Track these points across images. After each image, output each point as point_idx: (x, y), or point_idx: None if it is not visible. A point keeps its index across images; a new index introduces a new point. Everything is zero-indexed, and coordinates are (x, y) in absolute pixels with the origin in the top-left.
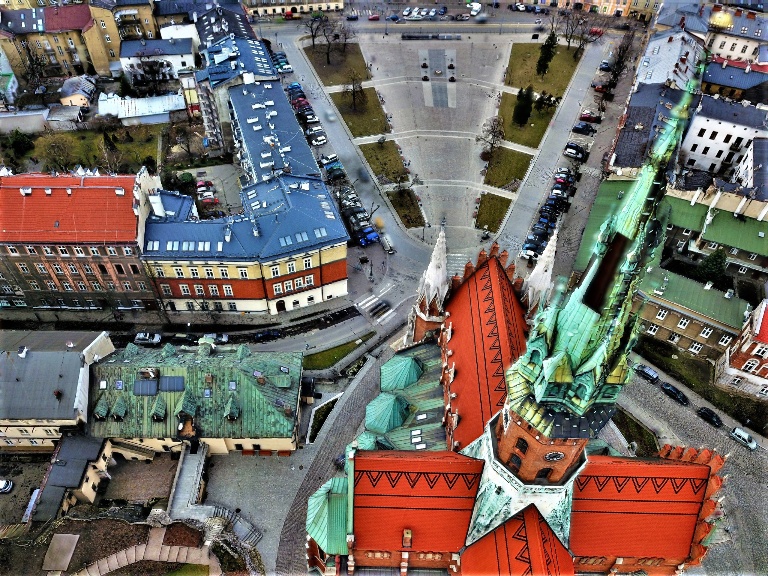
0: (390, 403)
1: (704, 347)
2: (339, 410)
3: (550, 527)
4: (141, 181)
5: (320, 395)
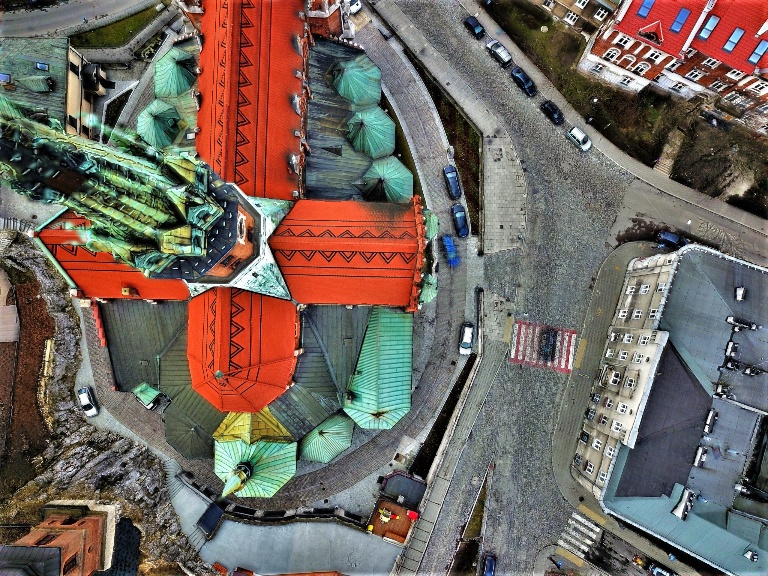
0: (151, 122)
1: (579, 19)
2: (134, 104)
3: (257, 292)
4: None
5: (113, 84)
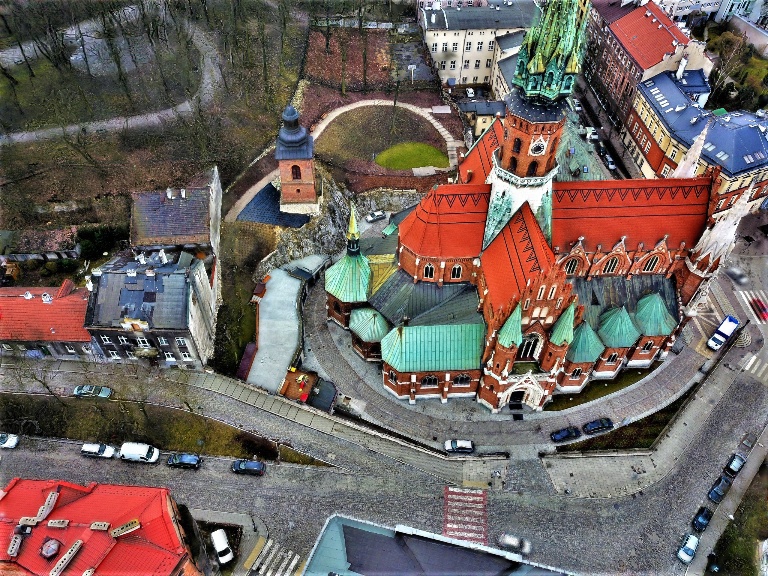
0: None
1: None
2: None
3: (487, 217)
4: (690, 46)
5: None
